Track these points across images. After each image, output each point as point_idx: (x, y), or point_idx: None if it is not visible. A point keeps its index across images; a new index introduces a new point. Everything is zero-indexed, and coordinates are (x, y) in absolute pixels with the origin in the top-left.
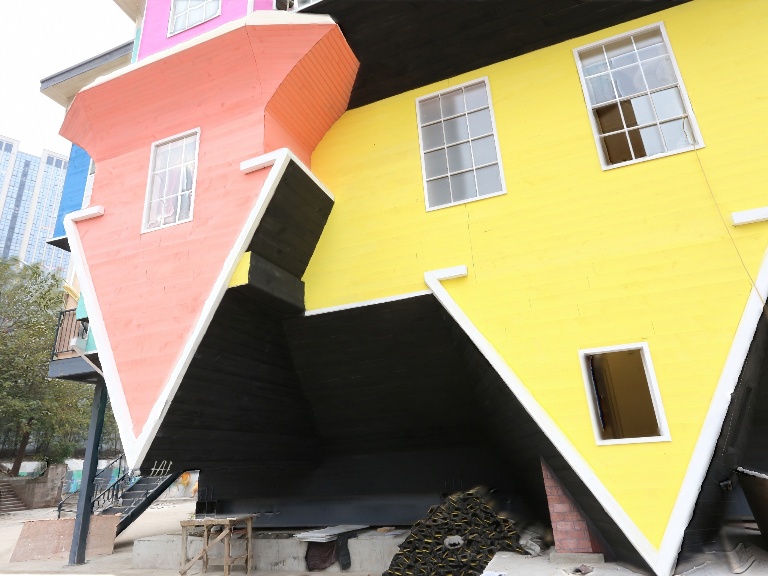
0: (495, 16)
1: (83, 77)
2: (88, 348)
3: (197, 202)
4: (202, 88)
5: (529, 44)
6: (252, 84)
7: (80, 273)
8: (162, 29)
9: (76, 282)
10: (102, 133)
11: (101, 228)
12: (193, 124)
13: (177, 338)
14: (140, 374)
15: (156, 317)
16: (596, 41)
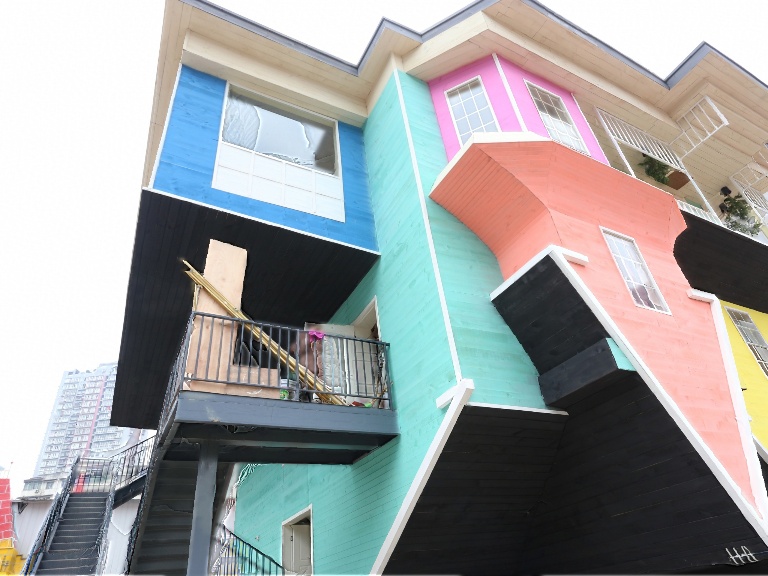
0: (710, 269)
1: (245, 34)
2: (470, 397)
3: (667, 301)
4: (637, 212)
5: (709, 291)
6: (665, 233)
7: (608, 319)
8: (541, 127)
9: (212, 275)
10: (556, 186)
11: (591, 279)
12: (629, 233)
13: (724, 420)
14: (718, 448)
15: (697, 394)
16: (731, 307)
